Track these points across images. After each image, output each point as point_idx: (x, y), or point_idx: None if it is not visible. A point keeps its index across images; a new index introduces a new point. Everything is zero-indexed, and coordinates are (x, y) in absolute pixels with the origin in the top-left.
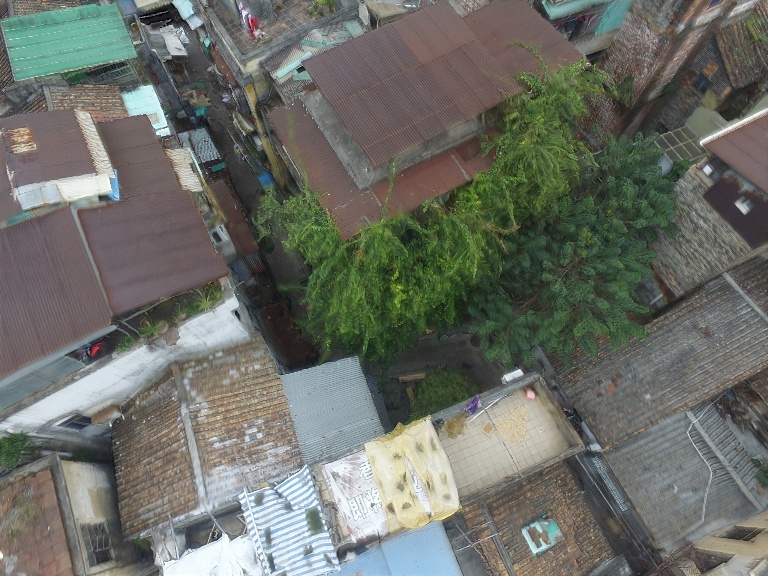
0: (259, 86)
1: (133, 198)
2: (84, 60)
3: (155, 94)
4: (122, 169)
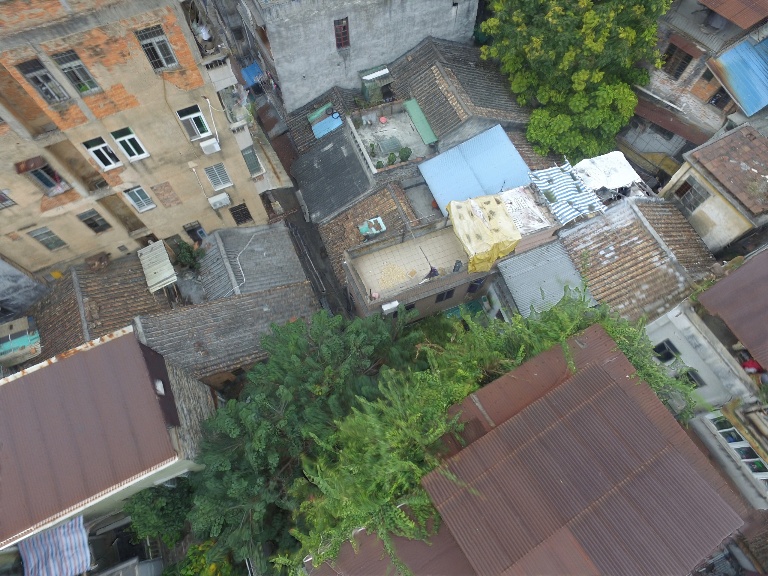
0: None
1: None
2: None
3: None
4: None
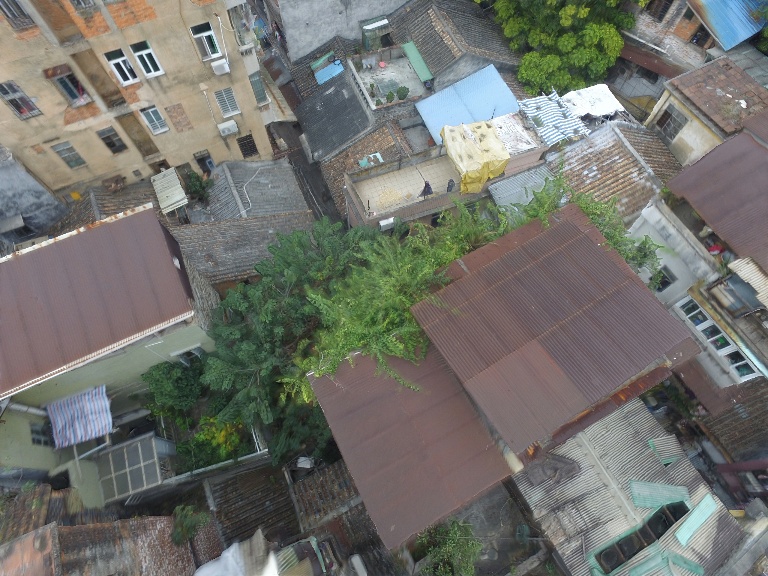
0: None
1: None
2: None
3: None
4: None
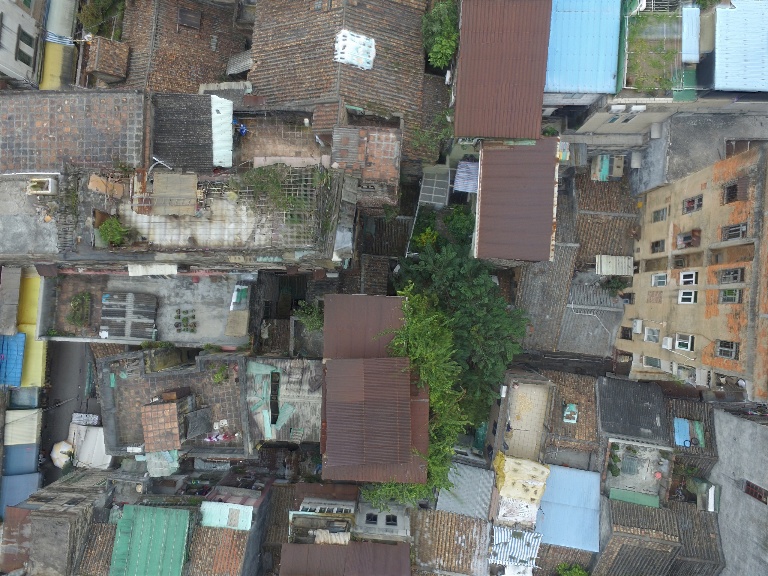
0: (255, 442)
1: (345, 575)
2: (176, 547)
3: (212, 502)
4: (322, 574)
